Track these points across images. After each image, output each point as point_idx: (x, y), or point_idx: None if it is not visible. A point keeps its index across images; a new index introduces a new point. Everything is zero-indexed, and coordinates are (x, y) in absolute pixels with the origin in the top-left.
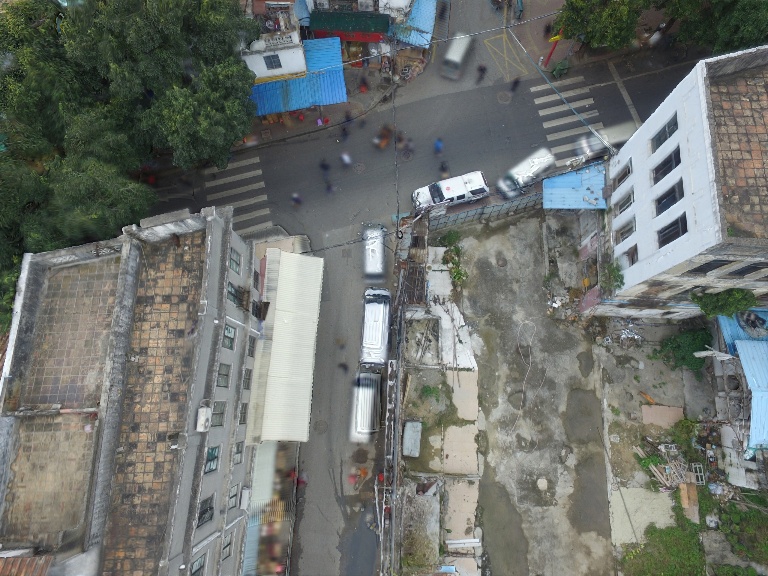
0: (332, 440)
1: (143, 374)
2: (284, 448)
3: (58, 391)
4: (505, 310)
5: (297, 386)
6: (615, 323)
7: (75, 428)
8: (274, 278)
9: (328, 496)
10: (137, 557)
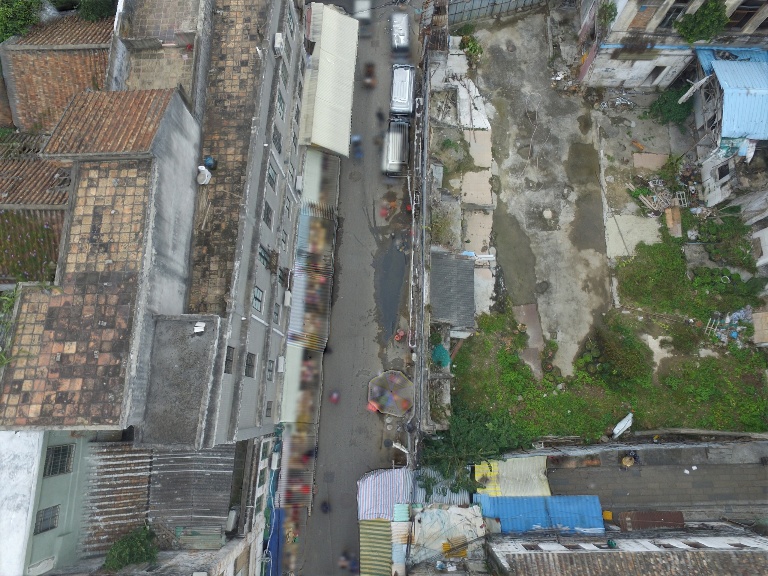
0: (365, 186)
1: (227, 23)
2: (328, 168)
3: (159, 34)
4: (515, 84)
5: (339, 112)
6: (610, 93)
7: (175, 57)
8: (319, 24)
9: (363, 227)
10: (229, 139)
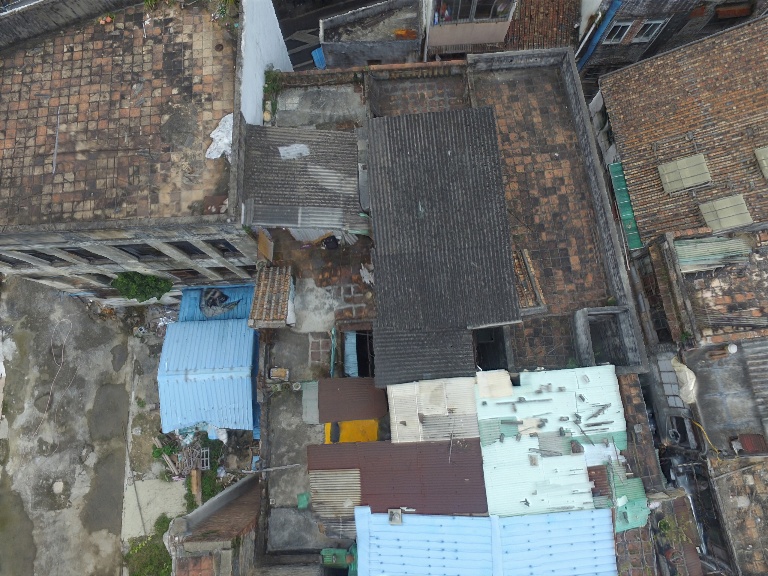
0: None
1: None
2: None
3: None
4: (43, 310)
5: None
6: (153, 311)
7: None
8: None
9: None
10: None
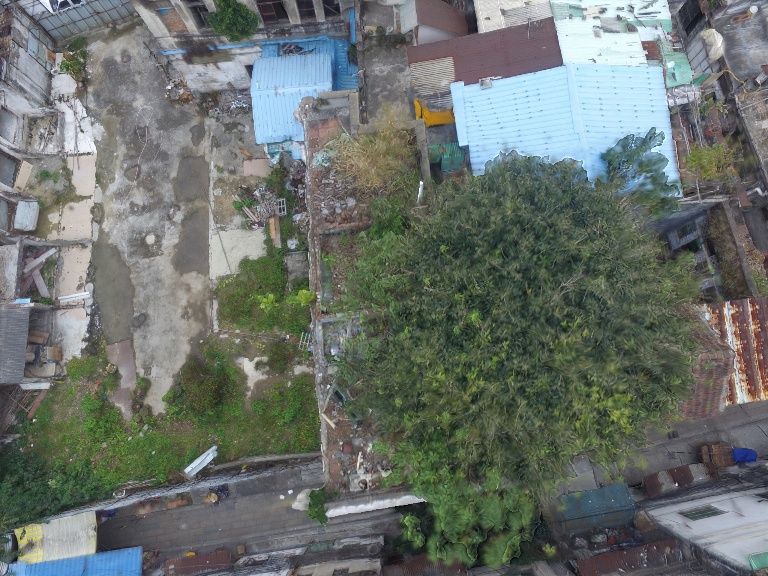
0: None
1: None
2: None
3: None
4: (126, 99)
5: None
6: (226, 96)
7: None
8: None
9: None
10: None
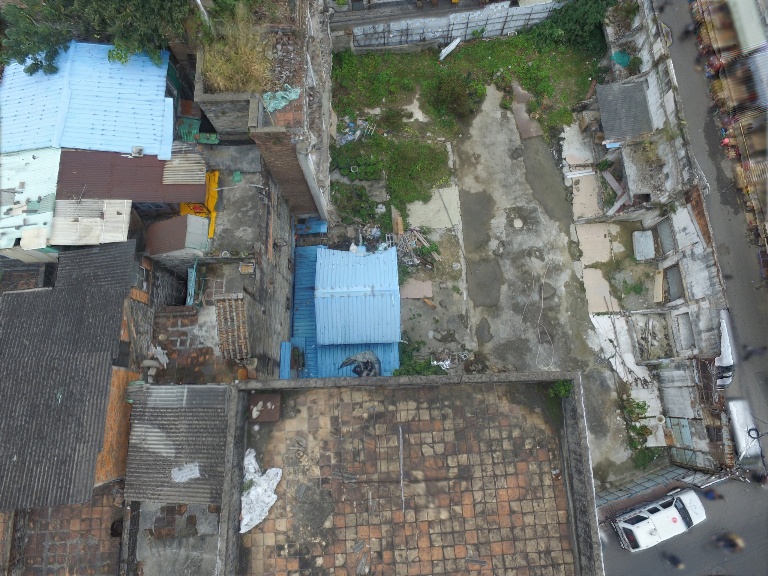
0: None
1: None
2: None
3: None
4: None
5: None
6: None
7: None
8: None
9: None
10: None
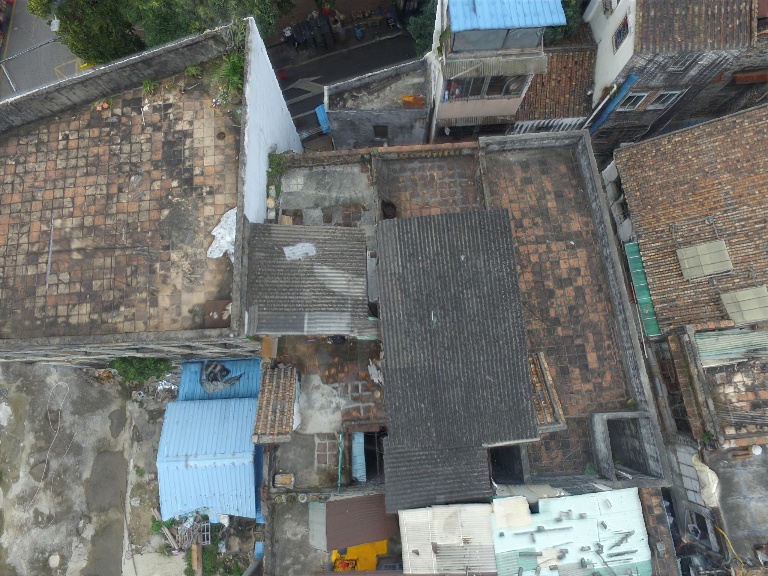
0: None
1: None
2: None
3: None
4: (39, 372)
5: None
6: None
7: None
8: None
9: None
10: None
